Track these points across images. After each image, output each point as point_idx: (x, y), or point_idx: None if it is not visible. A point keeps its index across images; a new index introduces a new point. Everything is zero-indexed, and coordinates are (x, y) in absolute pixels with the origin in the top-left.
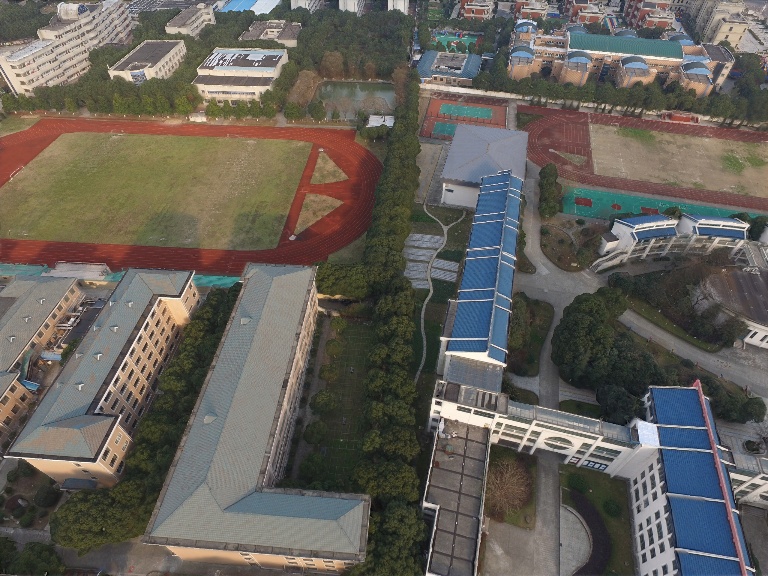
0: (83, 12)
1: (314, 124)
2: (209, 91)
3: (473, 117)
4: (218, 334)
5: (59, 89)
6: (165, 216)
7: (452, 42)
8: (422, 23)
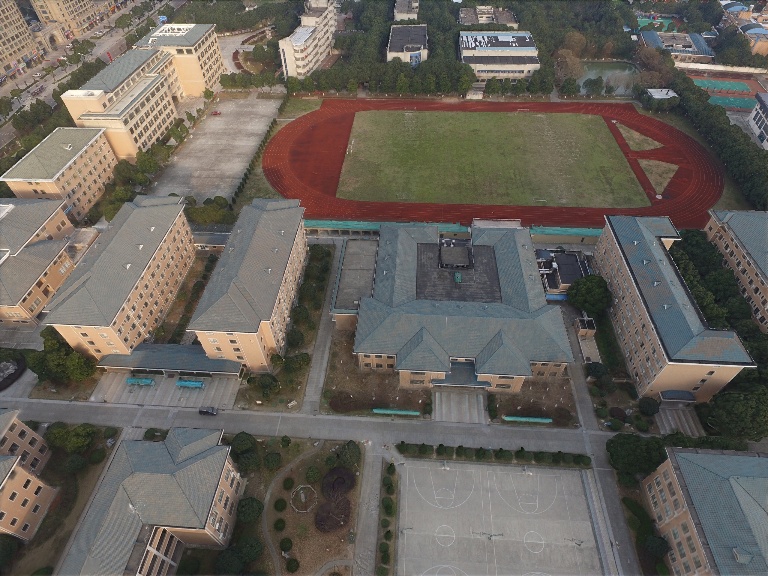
0: (329, 0)
1: (587, 99)
2: (479, 70)
3: (733, 90)
4: (727, 269)
5: (338, 71)
6: (522, 180)
7: None
8: (621, 6)
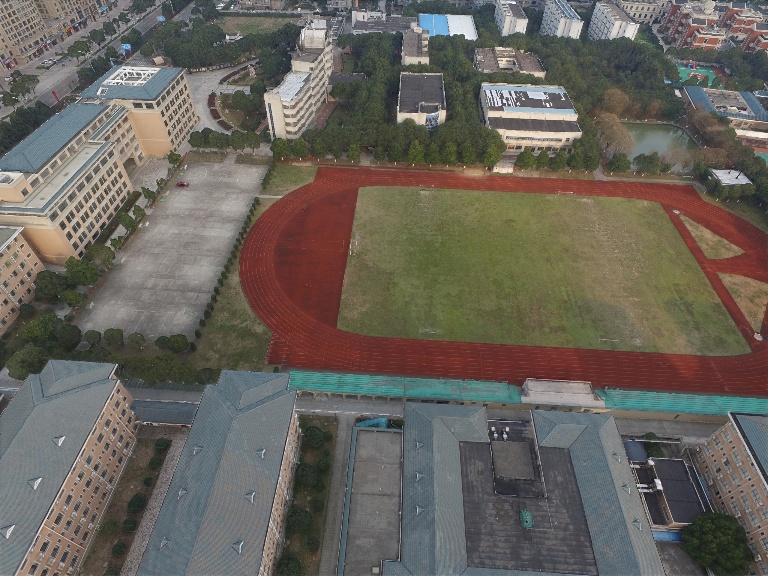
0: (326, 39)
1: (637, 177)
2: (508, 137)
3: None
4: None
5: (336, 132)
6: (579, 305)
7: (690, 74)
8: (657, 53)
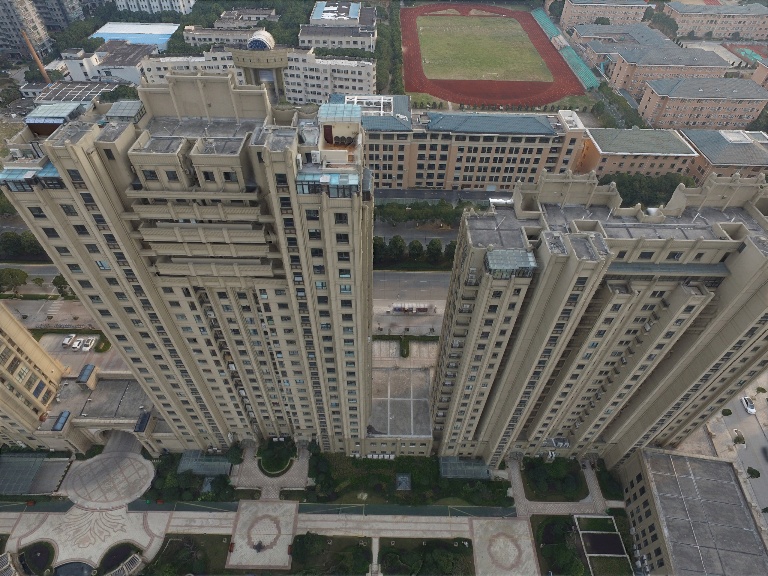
0: None
1: None
2: None
3: None
4: None
5: (383, 69)
6: (505, 37)
7: None
8: None
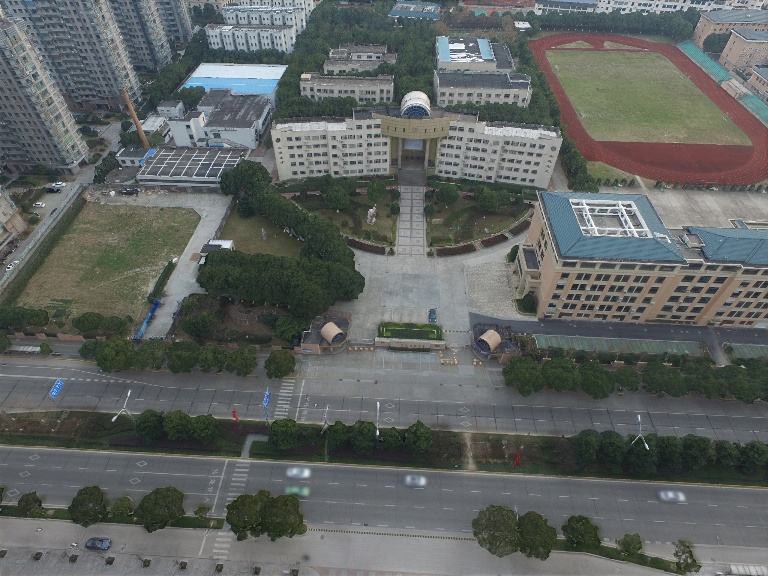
0: None
1: None
2: None
3: (487, 14)
4: None
5: None
6: (662, 80)
7: None
8: None
